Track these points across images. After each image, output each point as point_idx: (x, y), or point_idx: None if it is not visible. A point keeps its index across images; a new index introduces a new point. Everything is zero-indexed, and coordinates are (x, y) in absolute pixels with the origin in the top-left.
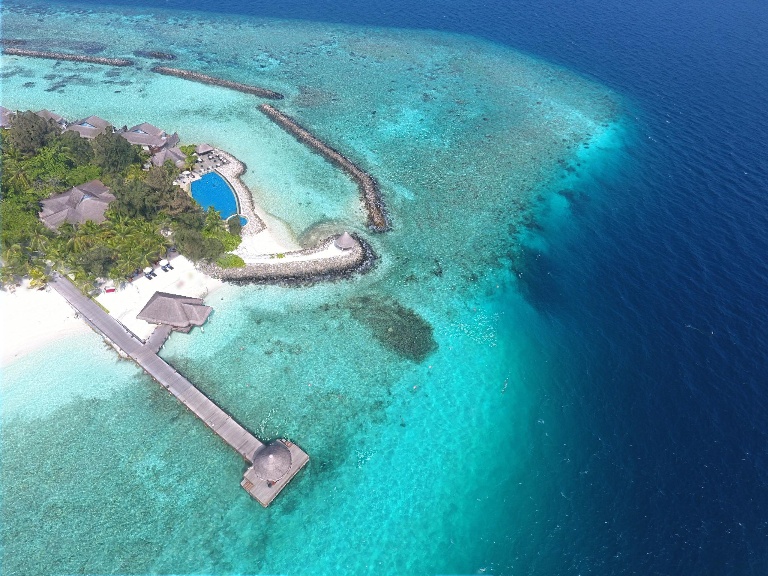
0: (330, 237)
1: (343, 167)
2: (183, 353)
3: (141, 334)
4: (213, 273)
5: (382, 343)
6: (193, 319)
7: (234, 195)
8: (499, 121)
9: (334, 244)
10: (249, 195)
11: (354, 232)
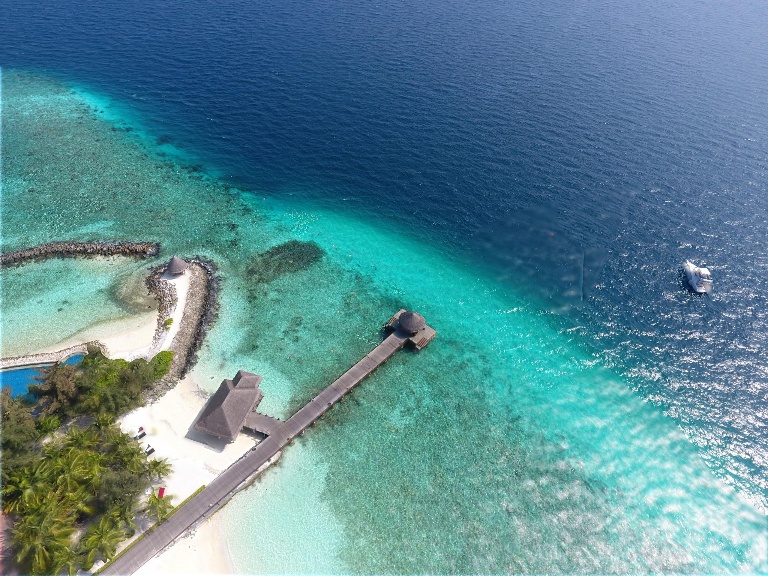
0: (148, 287)
1: (2, 265)
2: (282, 406)
3: (248, 447)
4: (169, 385)
5: (303, 268)
6: (255, 382)
7: (0, 371)
8: (3, 140)
9: (169, 279)
10: (3, 360)
11: (148, 269)
